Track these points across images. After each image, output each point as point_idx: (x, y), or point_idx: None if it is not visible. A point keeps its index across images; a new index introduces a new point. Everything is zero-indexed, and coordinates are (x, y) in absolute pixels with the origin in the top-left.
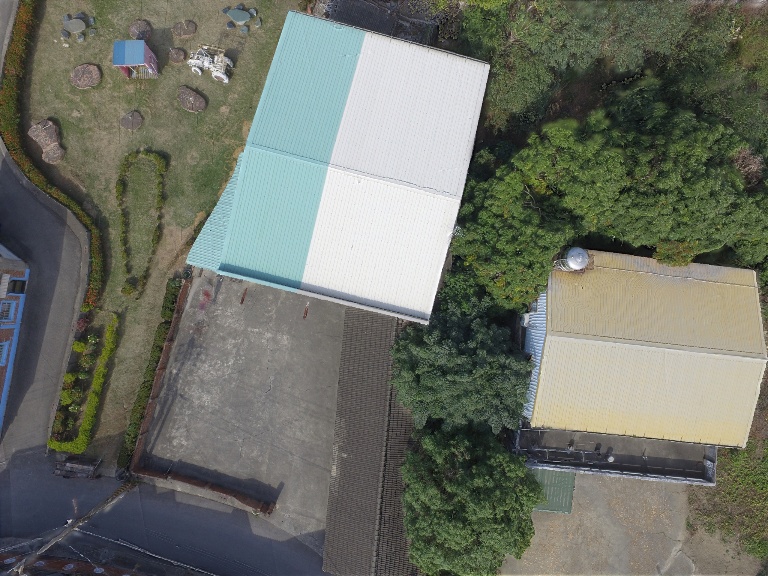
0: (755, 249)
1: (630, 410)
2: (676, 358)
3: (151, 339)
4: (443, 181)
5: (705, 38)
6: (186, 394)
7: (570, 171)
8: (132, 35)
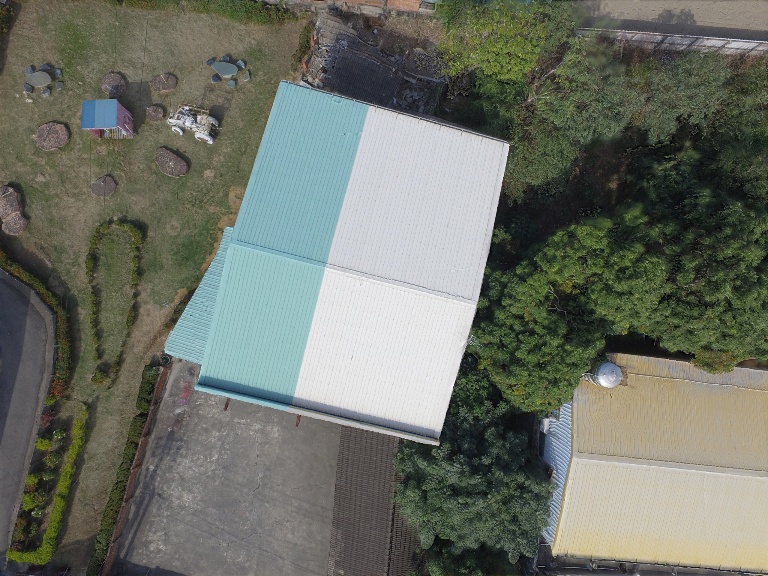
0: None
1: (664, 537)
2: (717, 481)
3: (125, 431)
4: (457, 283)
5: (742, 102)
6: (164, 493)
7: (603, 277)
8: (104, 90)
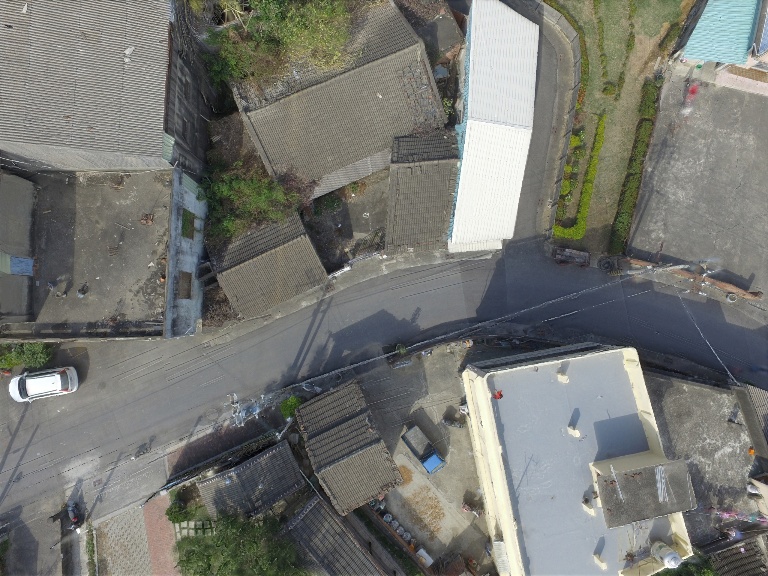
0: None
1: None
2: None
3: (626, 140)
4: None
5: None
6: (662, 190)
7: None
8: None
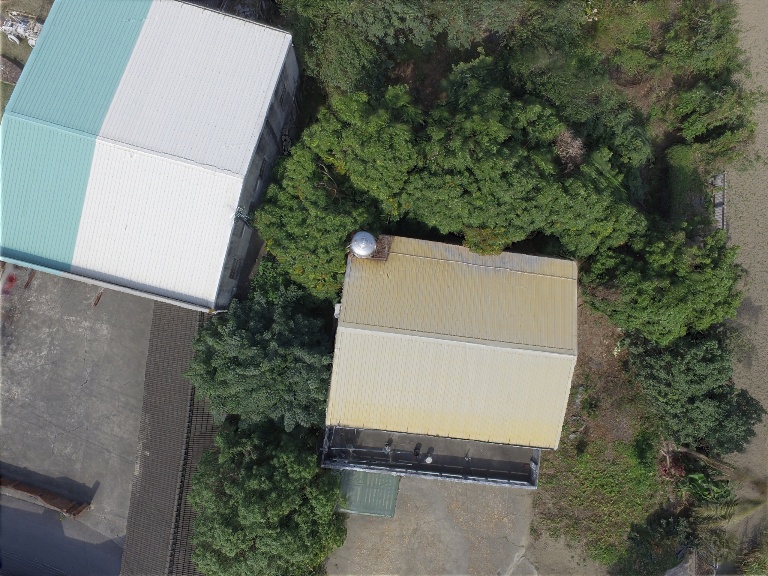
0: (580, 239)
1: (432, 408)
2: (479, 353)
3: None
4: (226, 158)
5: (552, 18)
6: None
7: (354, 149)
8: None
